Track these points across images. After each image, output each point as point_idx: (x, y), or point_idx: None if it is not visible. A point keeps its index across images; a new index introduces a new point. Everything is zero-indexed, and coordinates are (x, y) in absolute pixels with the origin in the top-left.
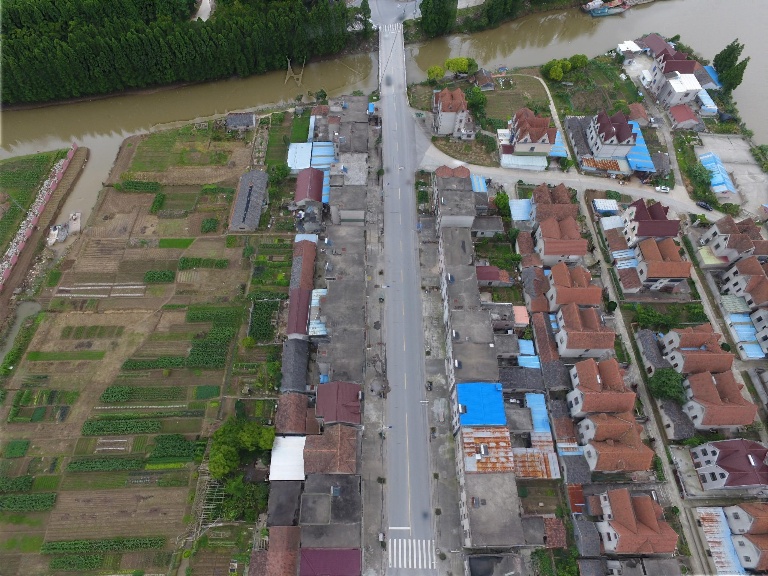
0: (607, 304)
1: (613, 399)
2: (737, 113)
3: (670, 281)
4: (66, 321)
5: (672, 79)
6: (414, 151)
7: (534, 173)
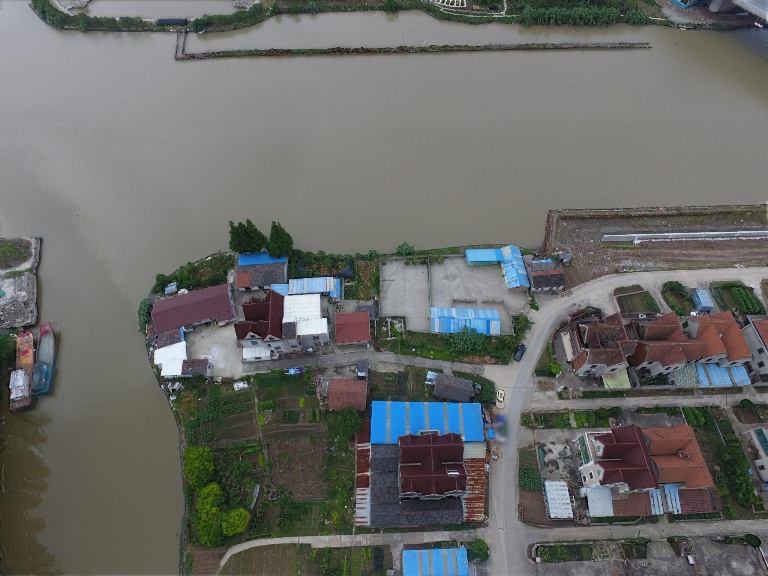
0: (737, 541)
1: None
2: (339, 256)
3: None
4: None
5: (296, 330)
6: None
7: None
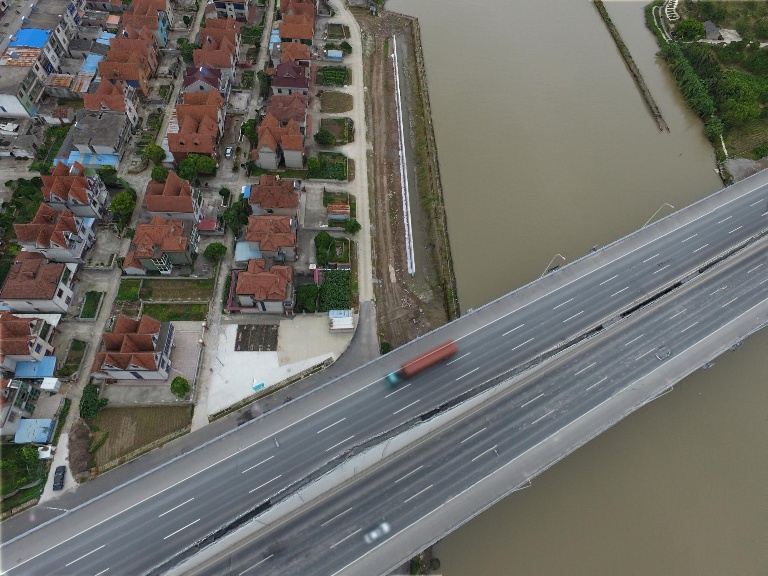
0: None
1: (131, 44)
2: None
3: (236, 8)
4: None
5: None
6: None
7: None
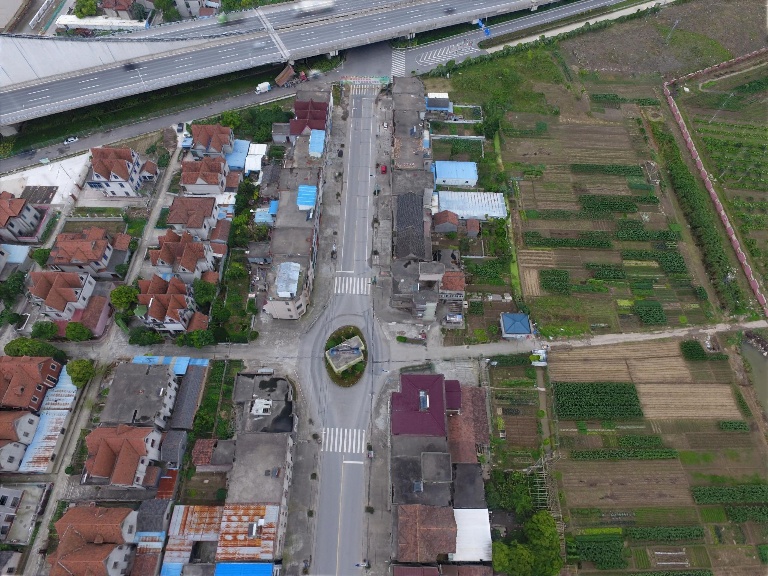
0: None
1: None
2: None
3: None
4: None
5: None
6: None
7: None
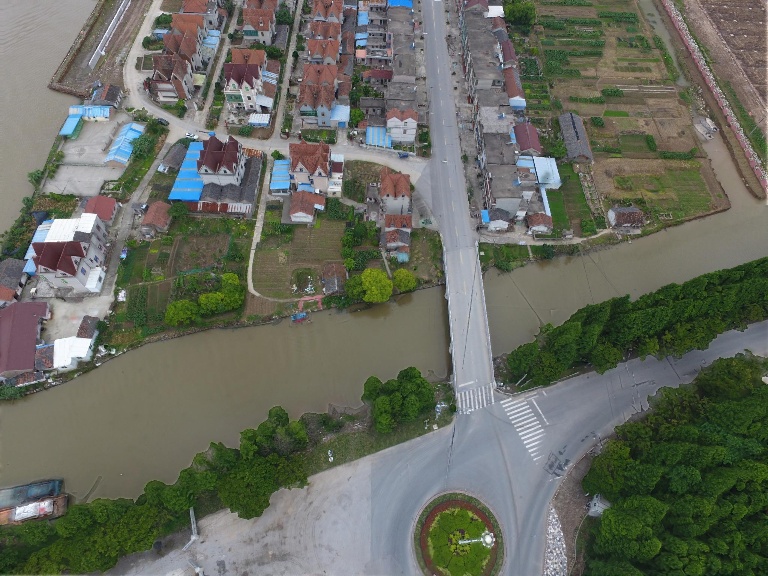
0: (295, 63)
1: None
2: None
3: None
4: (654, 74)
5: None
6: (433, 177)
7: None
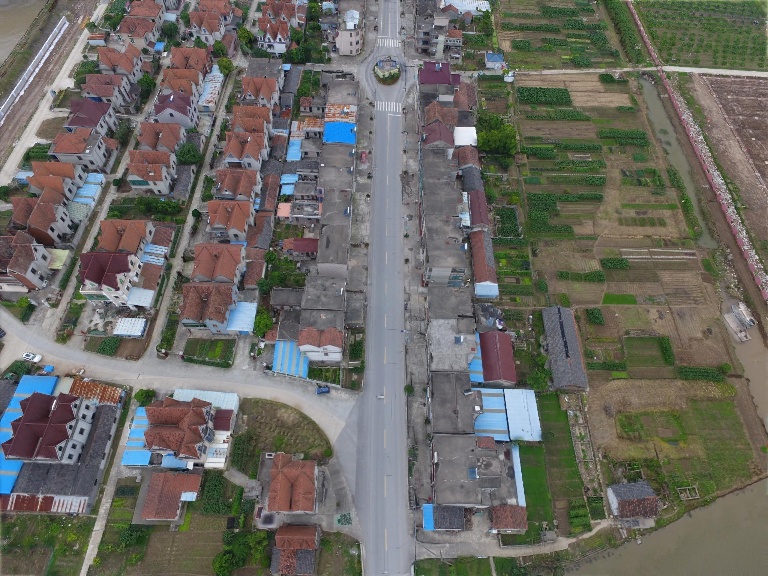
0: (197, 223)
1: None
2: None
3: None
4: (669, 230)
5: None
6: (361, 428)
7: (197, 388)
